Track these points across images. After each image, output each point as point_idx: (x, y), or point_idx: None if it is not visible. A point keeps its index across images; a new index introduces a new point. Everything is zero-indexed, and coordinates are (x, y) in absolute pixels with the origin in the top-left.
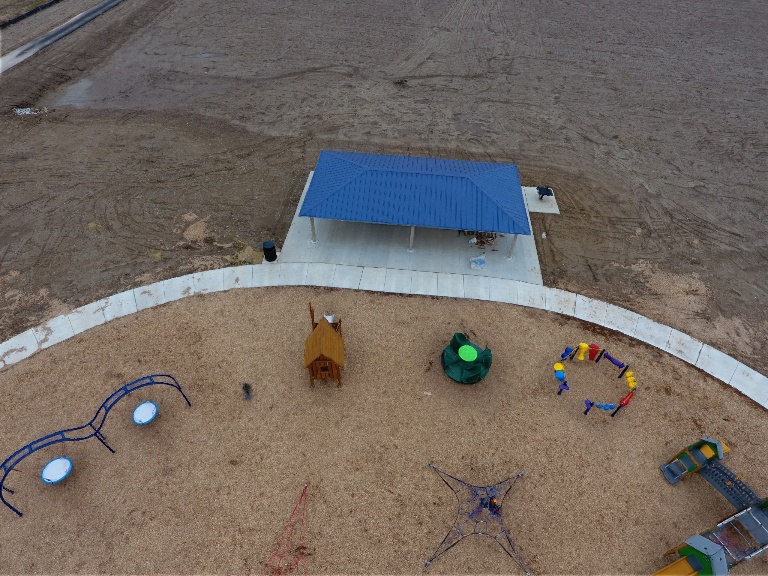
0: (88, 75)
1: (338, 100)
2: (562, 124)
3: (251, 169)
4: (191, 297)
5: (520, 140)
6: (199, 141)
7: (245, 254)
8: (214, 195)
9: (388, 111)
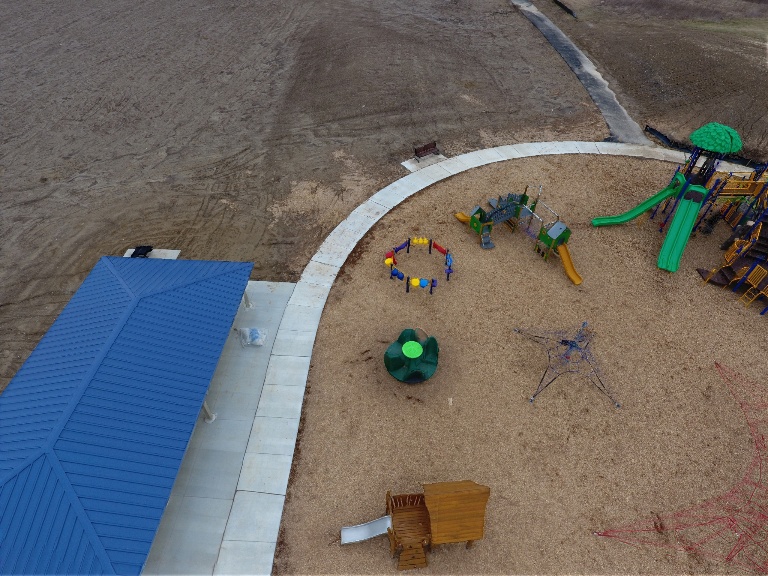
0: None
1: None
2: None
3: None
4: None
5: None
6: None
7: None
8: None
9: None
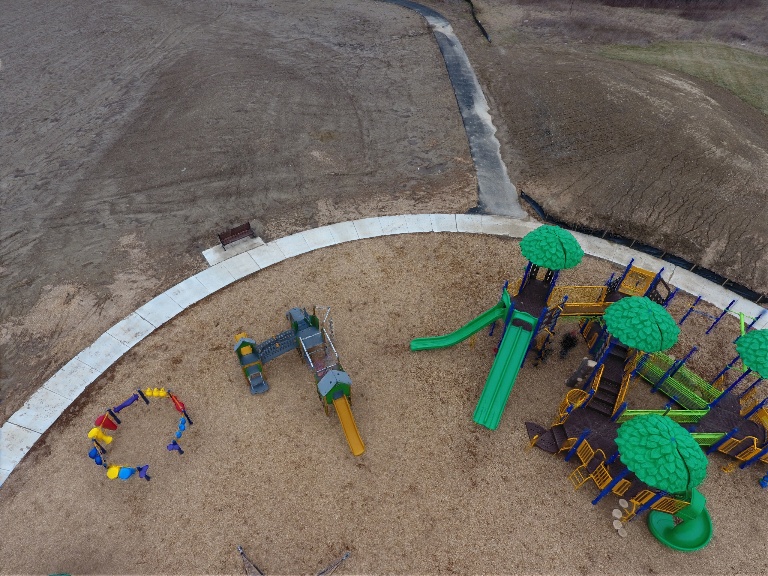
0: None
1: None
2: None
3: None
4: None
5: None
6: None
7: None
8: None
9: None
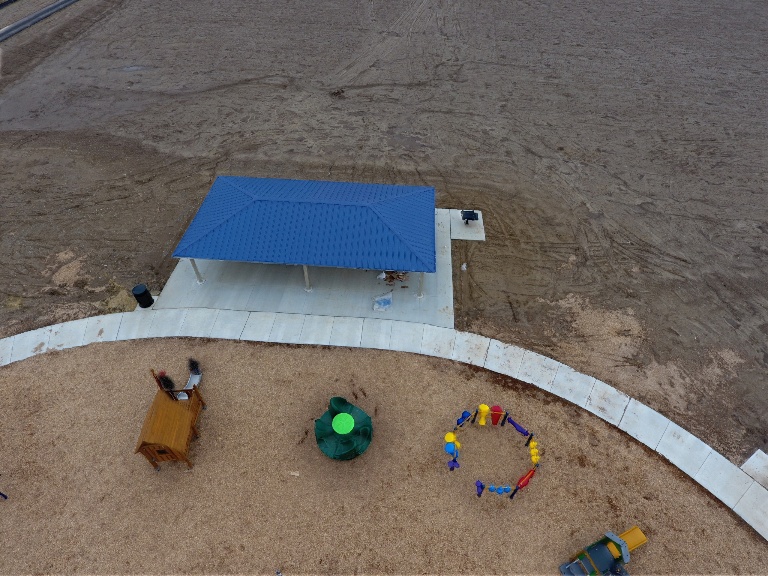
0: (0, 93)
1: (265, 114)
2: (505, 135)
3: (148, 197)
4: (42, 355)
5: (456, 155)
6: (97, 166)
7: (116, 300)
8: (99, 229)
9: (317, 125)
